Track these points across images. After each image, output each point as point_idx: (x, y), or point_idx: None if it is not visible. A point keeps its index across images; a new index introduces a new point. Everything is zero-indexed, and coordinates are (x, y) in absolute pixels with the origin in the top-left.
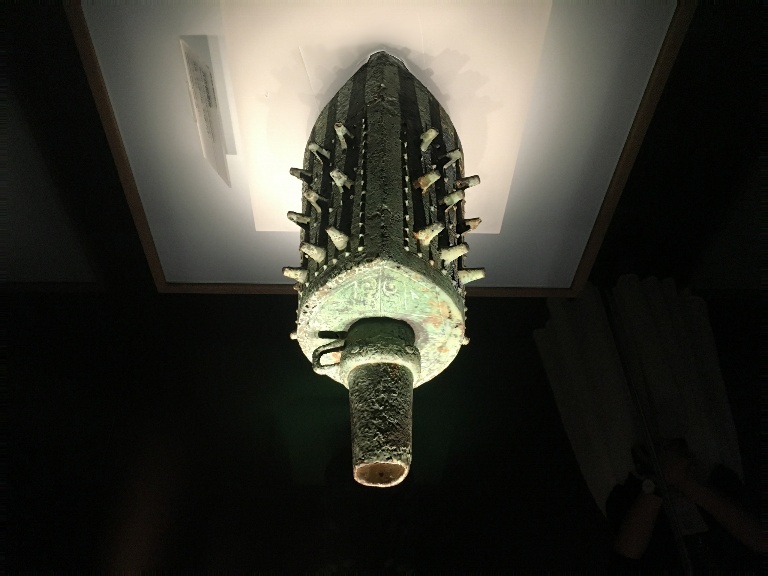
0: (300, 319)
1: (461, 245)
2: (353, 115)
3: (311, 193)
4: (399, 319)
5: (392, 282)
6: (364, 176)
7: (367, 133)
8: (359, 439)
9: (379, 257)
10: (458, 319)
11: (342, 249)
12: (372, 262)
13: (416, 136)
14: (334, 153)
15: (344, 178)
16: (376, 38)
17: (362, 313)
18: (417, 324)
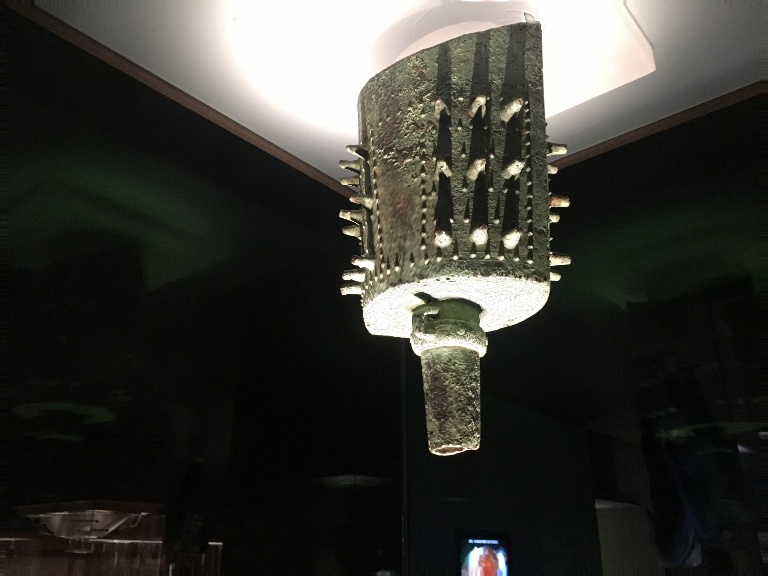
0: (426, 281)
1: (557, 274)
2: (513, 84)
3: (484, 163)
4: (482, 308)
5: (526, 295)
6: (530, 175)
7: (530, 122)
8: (457, 421)
9: (547, 281)
10: (512, 322)
11: (509, 248)
12: (541, 283)
13: (547, 142)
14: (490, 115)
15: (520, 170)
16: (540, 2)
17: (470, 297)
18: (484, 314)
